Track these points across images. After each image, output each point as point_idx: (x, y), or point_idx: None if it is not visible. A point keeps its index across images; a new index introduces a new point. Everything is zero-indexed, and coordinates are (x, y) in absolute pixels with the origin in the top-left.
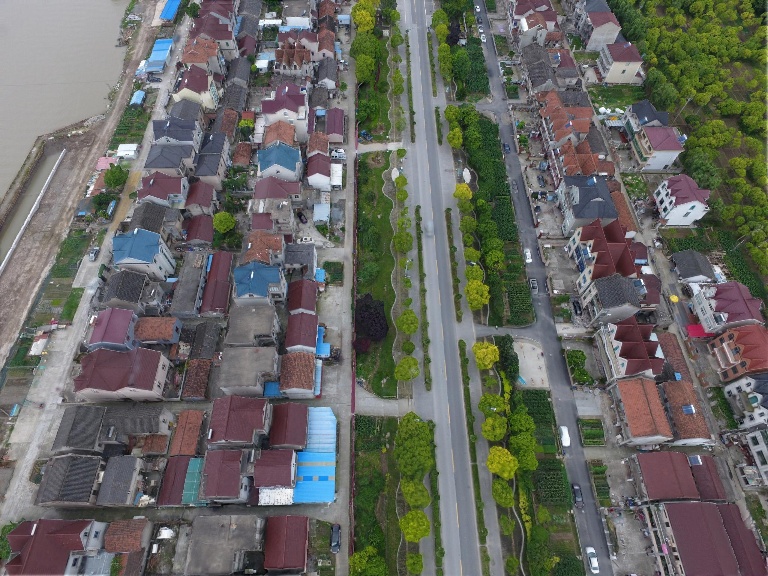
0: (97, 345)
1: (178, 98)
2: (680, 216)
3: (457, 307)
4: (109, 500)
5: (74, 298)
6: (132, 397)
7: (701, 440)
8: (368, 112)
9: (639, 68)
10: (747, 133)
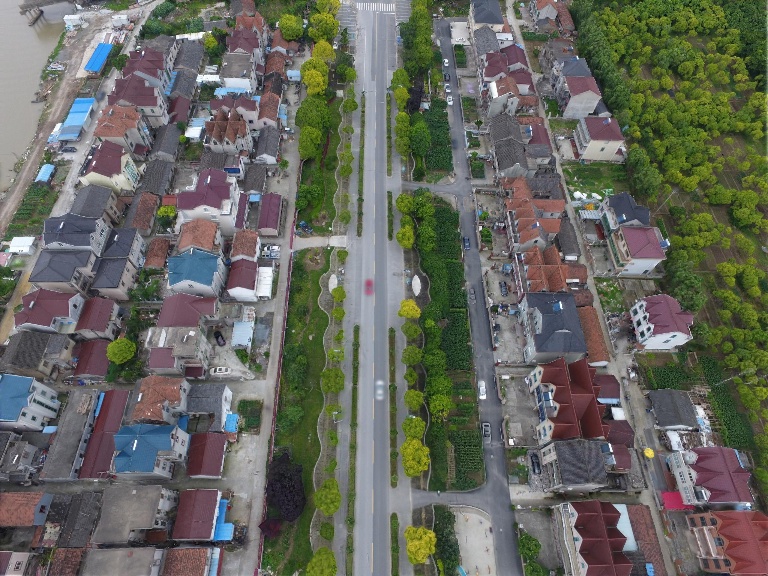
0: None
1: (86, 181)
2: (659, 342)
3: (392, 467)
4: None
5: None
6: None
7: None
8: (309, 198)
9: None
10: (737, 226)
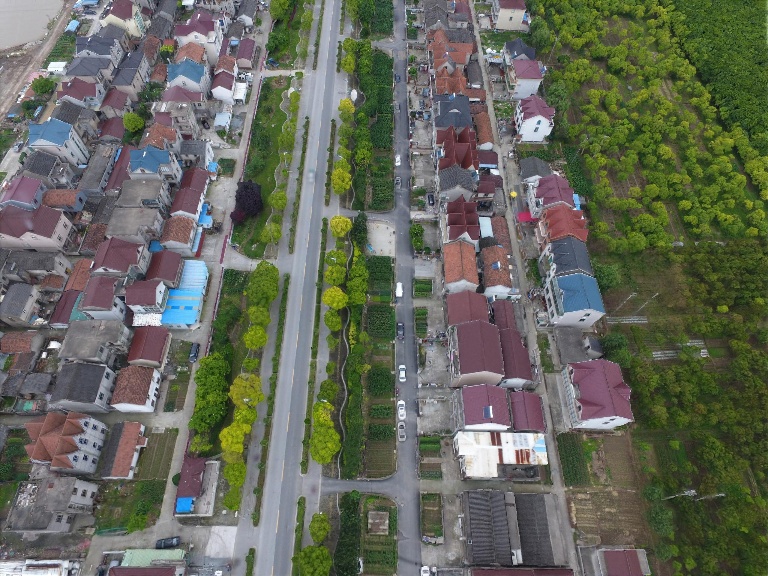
0: (7, 203)
1: (105, 24)
2: (531, 131)
3: (327, 194)
4: (5, 312)
5: None
6: (36, 247)
7: (504, 289)
8: (276, 43)
9: (528, 18)
10: (611, 73)
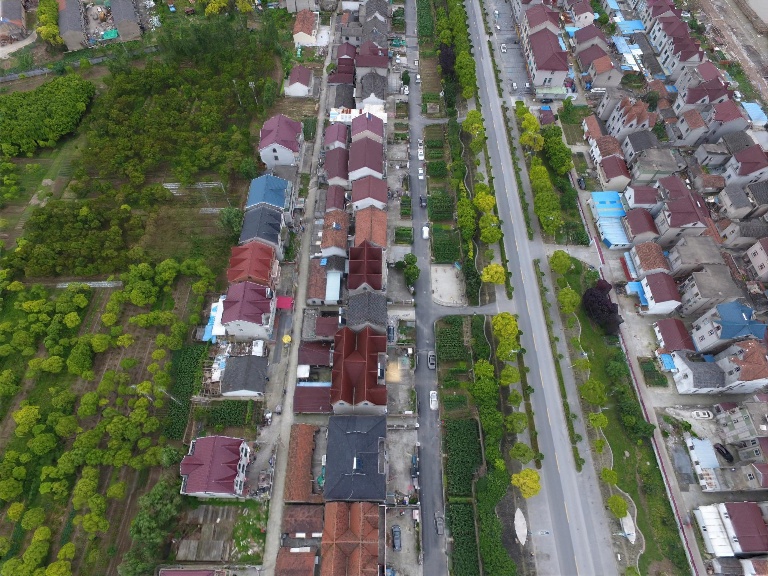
0: None
1: None
2: None
3: None
4: (736, 185)
5: None
6: None
7: None
8: None
9: None
10: None
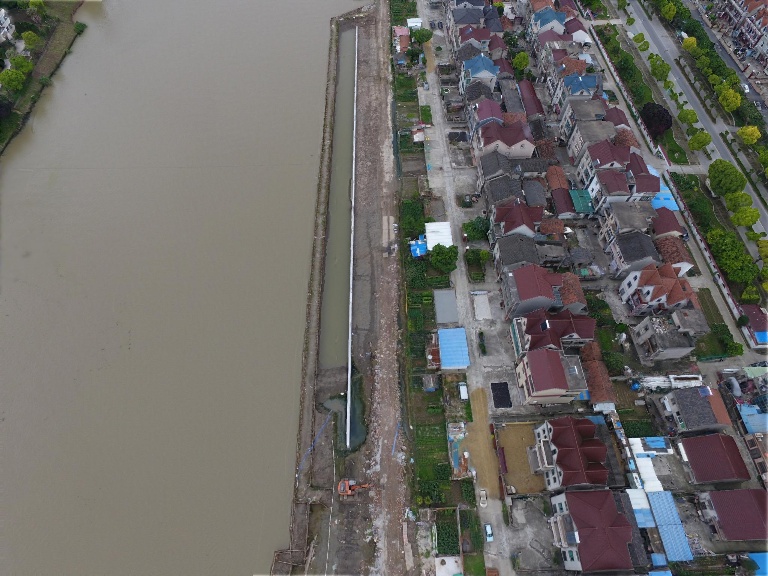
0: (487, 120)
1: None
2: None
3: (710, 114)
4: (540, 201)
5: (426, 111)
6: (513, 156)
7: None
8: None
9: None
10: None
